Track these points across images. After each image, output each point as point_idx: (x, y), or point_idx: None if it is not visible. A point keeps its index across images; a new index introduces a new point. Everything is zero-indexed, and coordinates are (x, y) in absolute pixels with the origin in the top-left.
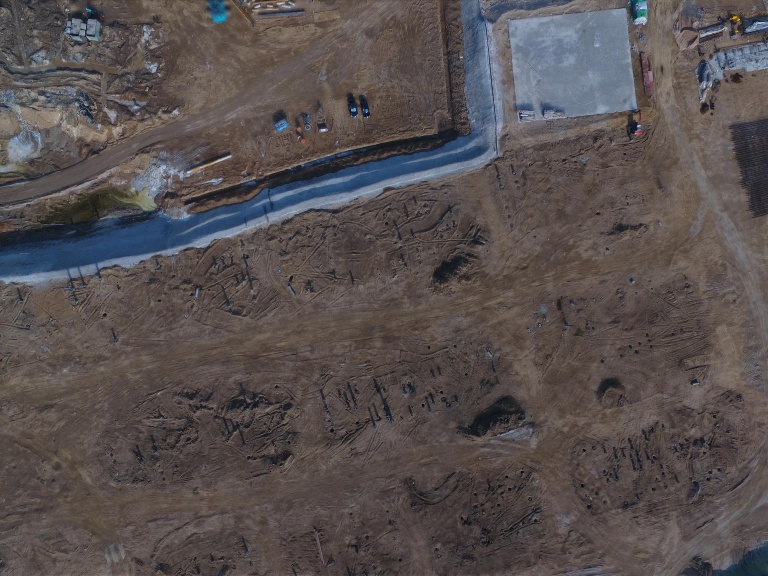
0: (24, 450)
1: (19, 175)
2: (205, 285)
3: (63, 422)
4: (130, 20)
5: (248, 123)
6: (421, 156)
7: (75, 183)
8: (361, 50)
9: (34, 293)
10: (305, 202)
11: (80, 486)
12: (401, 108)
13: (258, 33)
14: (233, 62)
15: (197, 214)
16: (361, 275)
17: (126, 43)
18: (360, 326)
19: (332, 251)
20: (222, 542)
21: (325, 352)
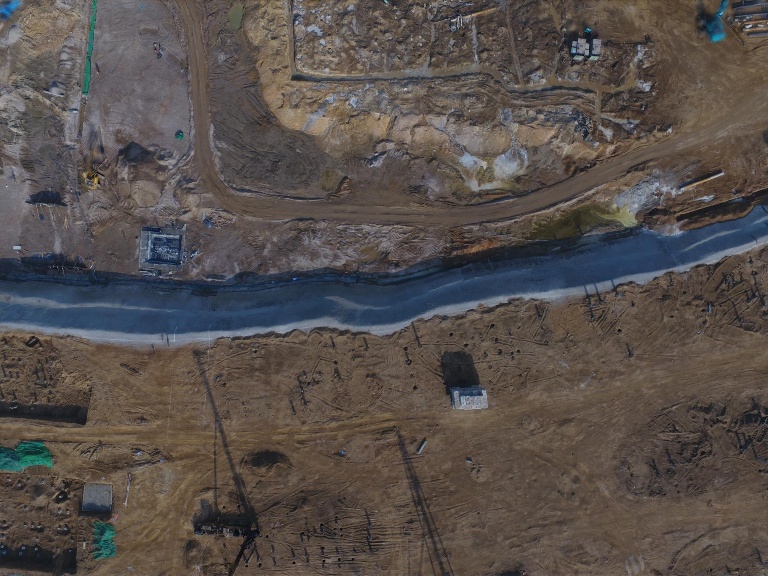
0: (544, 464)
1: (505, 192)
2: (717, 301)
3: (581, 436)
4: (623, 39)
5: (738, 141)
6: None
7: (562, 200)
8: None
9: (551, 309)
10: None
11: (598, 499)
12: None
13: (747, 52)
14: (724, 81)
15: (690, 231)
16: None
17: (619, 62)
18: None
19: None
20: (737, 554)
21: None
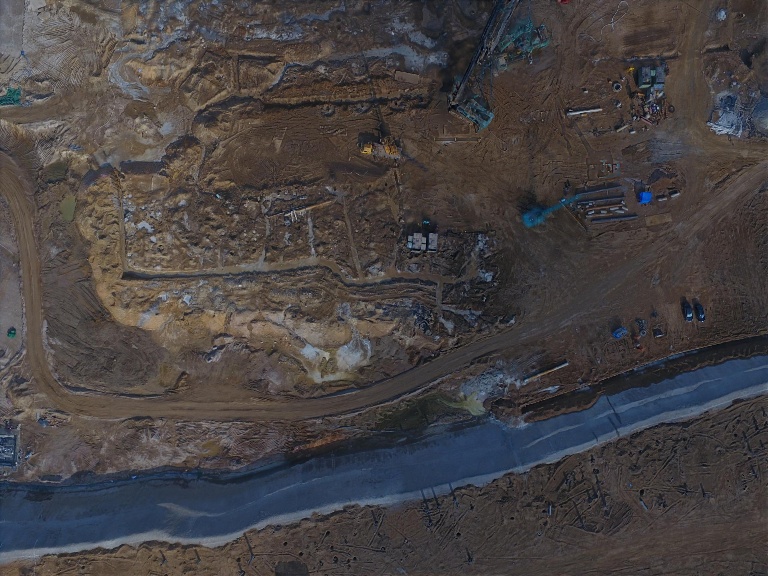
0: None
1: (349, 383)
2: (557, 502)
3: None
4: (463, 228)
5: (583, 330)
6: (762, 362)
7: (407, 391)
8: (693, 253)
9: (388, 515)
10: (656, 416)
11: None
12: (734, 311)
13: (591, 238)
14: (567, 269)
15: (535, 423)
16: (712, 488)
17: (460, 252)
18: (711, 539)
19: (683, 464)
20: None
21: (677, 565)
